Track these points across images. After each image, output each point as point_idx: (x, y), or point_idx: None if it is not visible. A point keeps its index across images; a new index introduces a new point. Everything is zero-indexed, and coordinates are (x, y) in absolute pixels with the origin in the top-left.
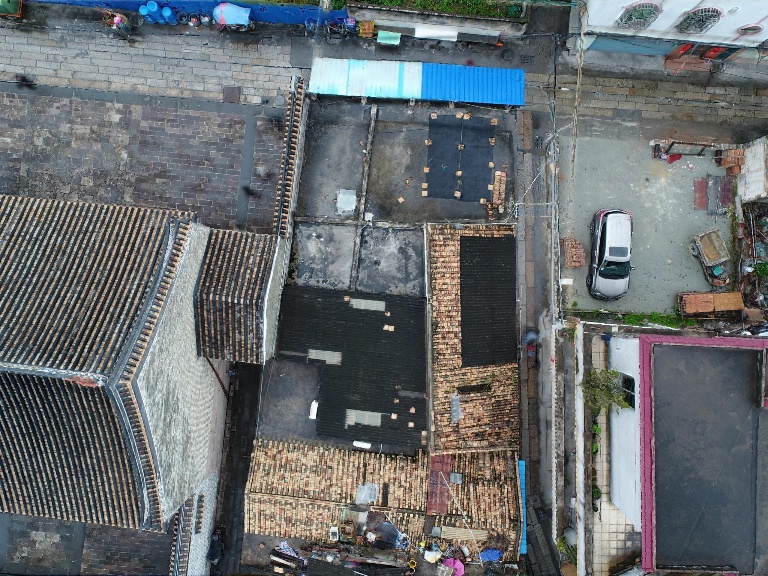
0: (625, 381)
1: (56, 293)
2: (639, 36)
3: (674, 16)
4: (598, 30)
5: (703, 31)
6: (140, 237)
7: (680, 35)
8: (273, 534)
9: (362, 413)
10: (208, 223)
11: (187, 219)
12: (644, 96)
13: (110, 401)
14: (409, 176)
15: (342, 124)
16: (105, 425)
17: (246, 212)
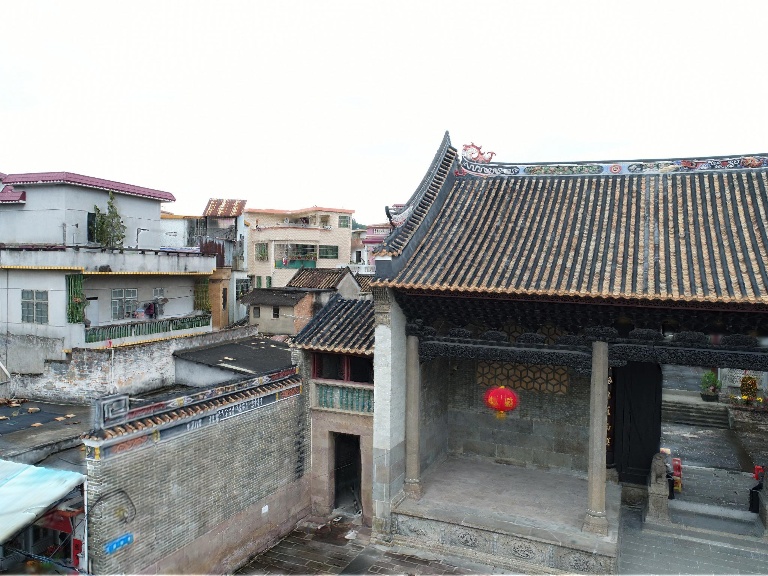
0: (91, 233)
1: (544, 224)
2: None
3: None
4: None
5: None
6: (448, 266)
7: None
8: None
9: None
10: (430, 567)
11: (376, 251)
12: None
13: None
14: (67, 425)
15: (85, 467)
16: None
17: (352, 564)
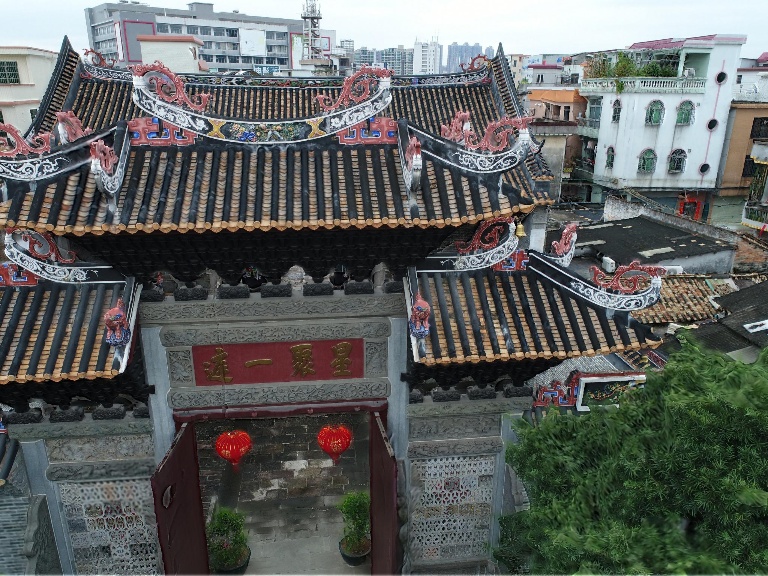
0: None
1: None
2: (653, 187)
3: (664, 162)
4: (630, 186)
5: (683, 170)
6: None
7: (673, 183)
8: (652, 319)
9: (653, 250)
10: None
11: None
12: (678, 207)
13: (481, 104)
14: None
15: None
16: (476, 123)
17: None
